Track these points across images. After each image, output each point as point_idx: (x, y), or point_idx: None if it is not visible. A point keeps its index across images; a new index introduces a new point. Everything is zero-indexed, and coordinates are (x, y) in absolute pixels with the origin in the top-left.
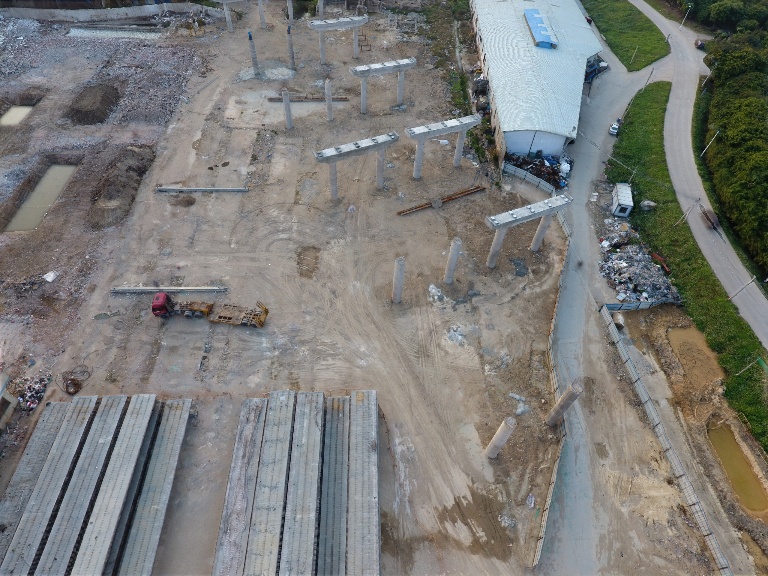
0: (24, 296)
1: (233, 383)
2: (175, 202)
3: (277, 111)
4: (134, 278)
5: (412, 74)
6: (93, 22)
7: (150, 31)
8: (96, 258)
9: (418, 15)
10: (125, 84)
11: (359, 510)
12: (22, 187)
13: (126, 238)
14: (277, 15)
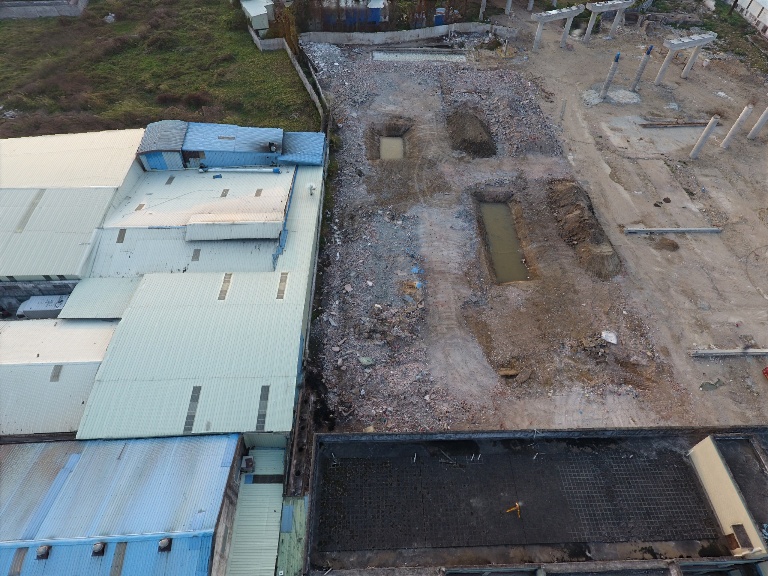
0: (603, 362)
1: None
2: (656, 245)
3: (662, 138)
4: (698, 338)
5: (759, 94)
6: (388, 45)
7: (451, 53)
8: (636, 314)
9: (700, 30)
10: (479, 111)
11: None
12: (479, 230)
13: (645, 289)
14: (562, 33)
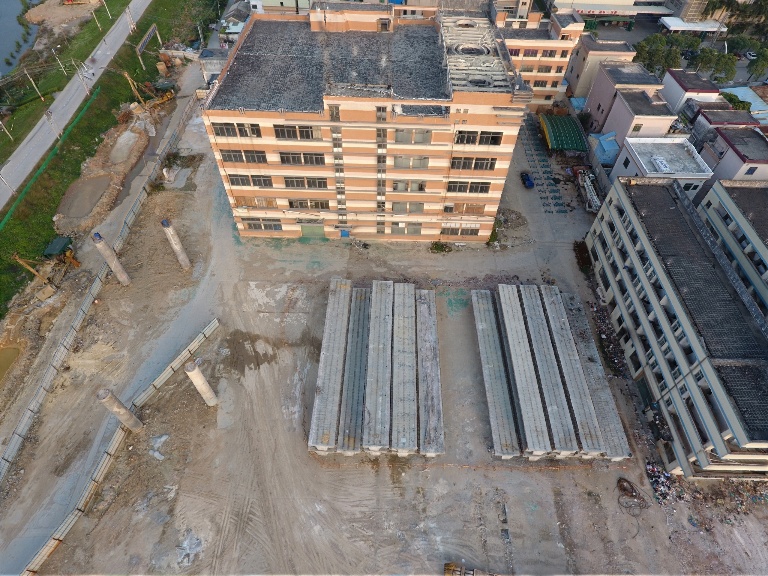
0: None
1: (463, 484)
2: None
3: None
4: None
5: None
6: None
7: None
8: None
9: None
10: None
11: (336, 348)
12: None
13: None
14: None
